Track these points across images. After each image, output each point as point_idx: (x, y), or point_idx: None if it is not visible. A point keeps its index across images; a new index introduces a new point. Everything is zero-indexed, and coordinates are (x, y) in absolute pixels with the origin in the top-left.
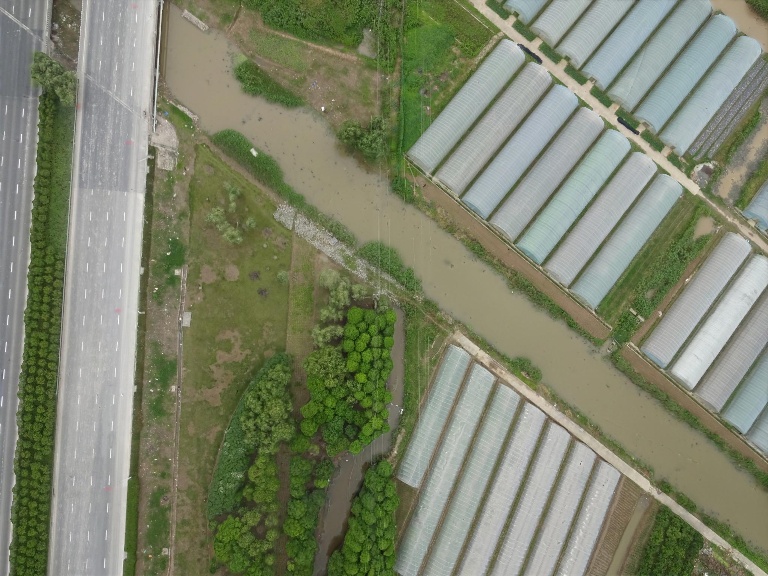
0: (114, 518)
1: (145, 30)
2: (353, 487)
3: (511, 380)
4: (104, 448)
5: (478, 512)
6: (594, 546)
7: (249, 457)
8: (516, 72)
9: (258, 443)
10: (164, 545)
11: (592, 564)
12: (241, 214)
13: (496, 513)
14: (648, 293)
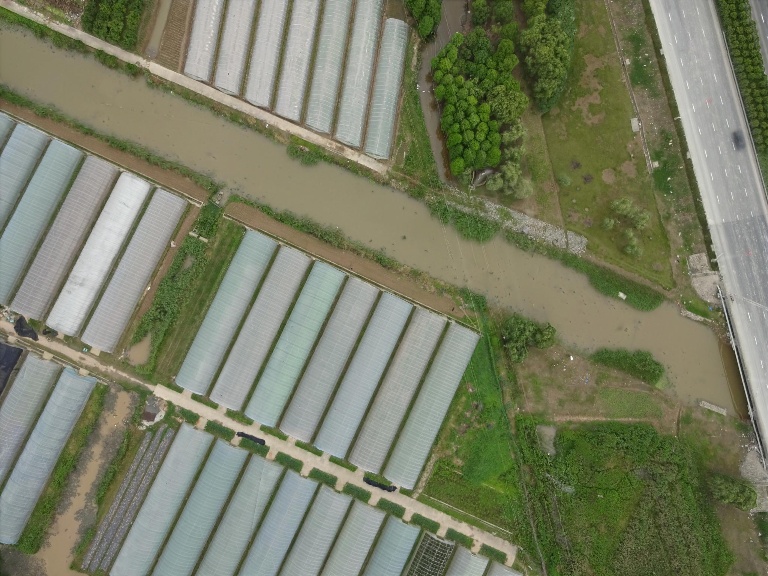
0: None
1: (757, 379)
2: None
3: (319, 139)
4: None
5: (322, 9)
6: (197, 0)
7: (550, 12)
8: (389, 459)
9: (548, 23)
10: None
11: None
12: (617, 233)
13: None
14: (190, 263)
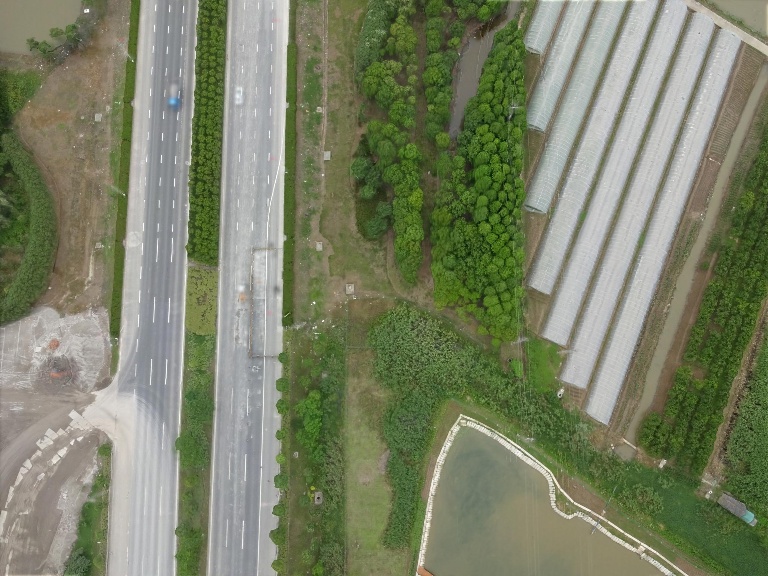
0: (277, 77)
1: None
2: (480, 73)
3: None
4: (267, 22)
5: (601, 76)
6: (719, 106)
7: (390, 21)
8: None
9: (397, 5)
10: (318, 104)
11: (719, 122)
12: None
13: (619, 77)
14: None
